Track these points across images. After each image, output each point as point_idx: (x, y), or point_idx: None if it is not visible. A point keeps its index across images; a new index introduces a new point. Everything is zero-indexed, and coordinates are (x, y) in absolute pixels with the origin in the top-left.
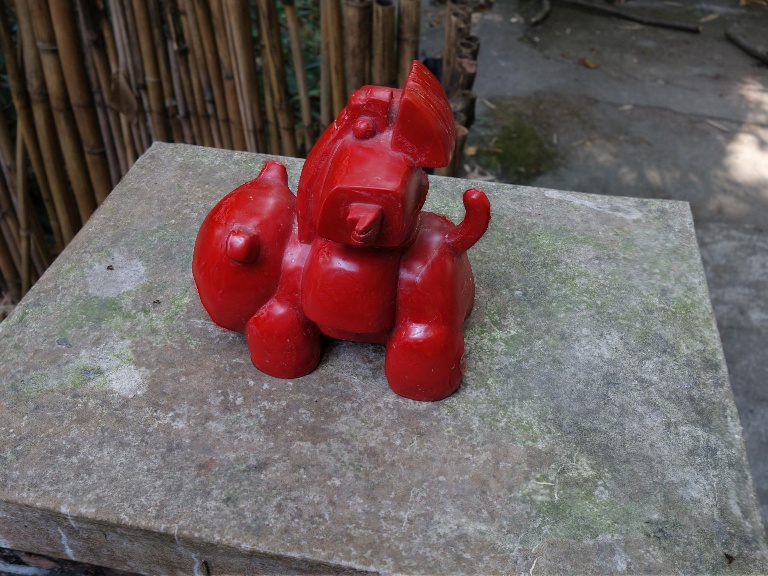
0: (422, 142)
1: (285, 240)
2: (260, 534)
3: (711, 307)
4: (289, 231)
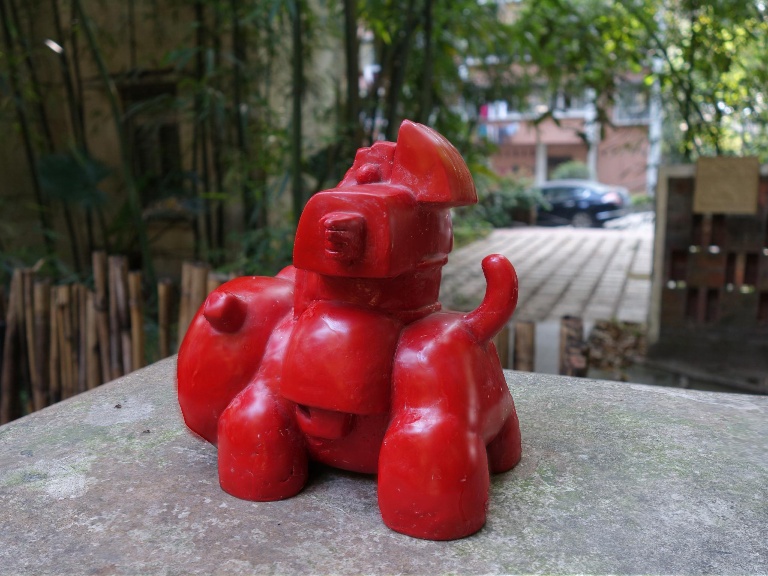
0: (423, 171)
1: (278, 318)
2: None
3: None
4: (286, 311)
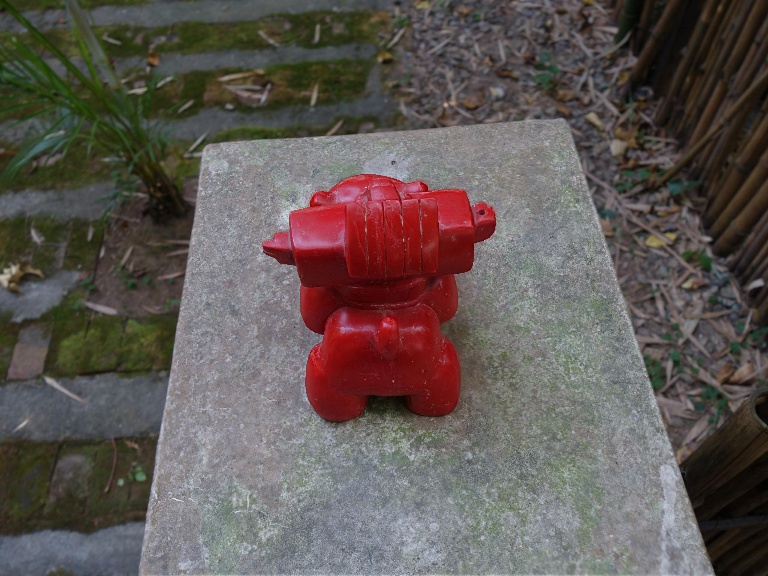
0: None
1: None
2: (186, 329)
3: None
4: None
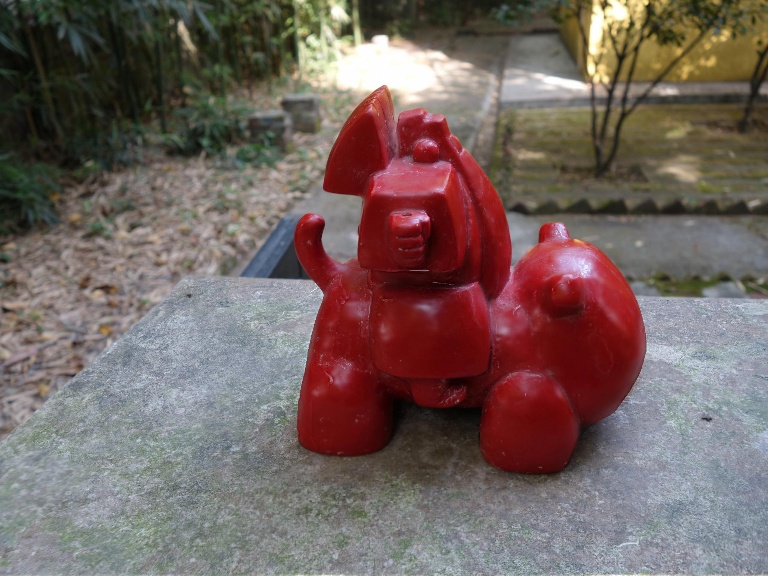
0: None
1: None
2: None
3: (1, 442)
4: None
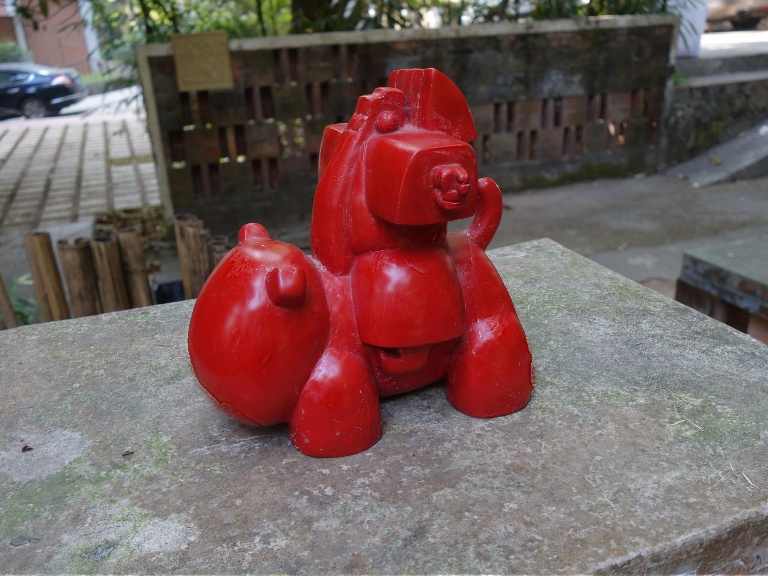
0: (454, 116)
1: (319, 278)
2: None
3: None
4: (317, 270)
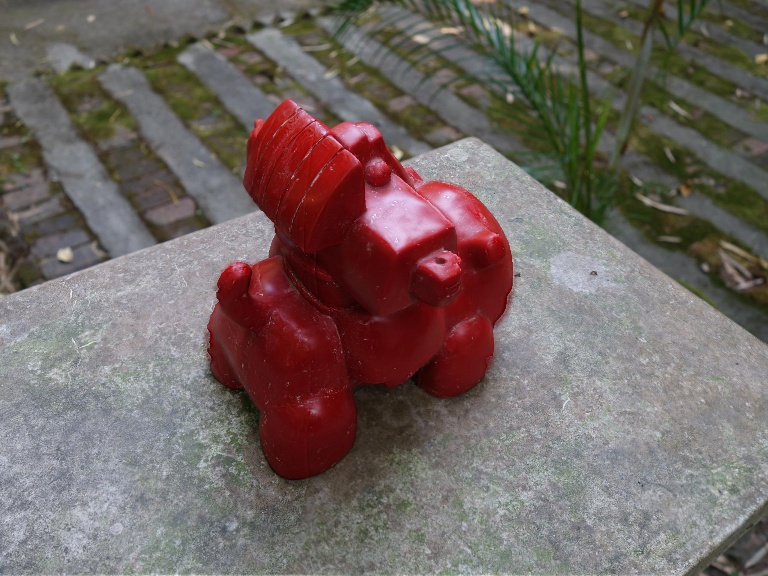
0: None
1: None
2: (257, 217)
3: None
4: None
